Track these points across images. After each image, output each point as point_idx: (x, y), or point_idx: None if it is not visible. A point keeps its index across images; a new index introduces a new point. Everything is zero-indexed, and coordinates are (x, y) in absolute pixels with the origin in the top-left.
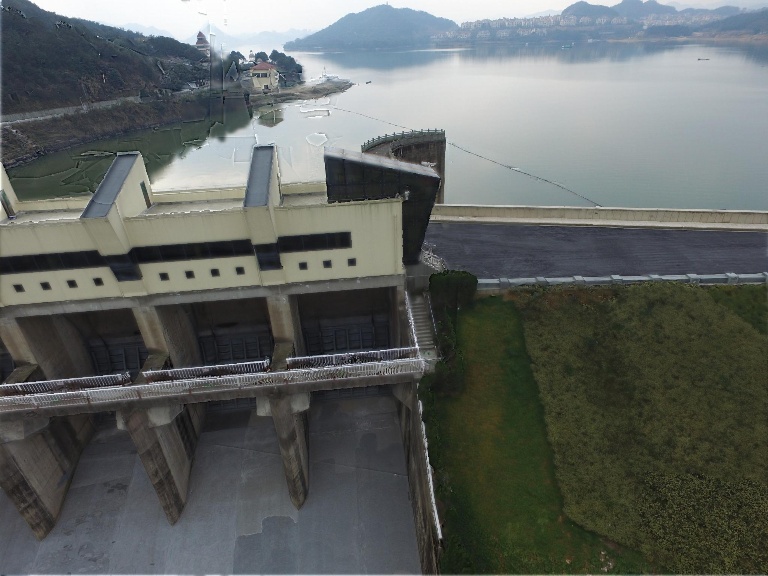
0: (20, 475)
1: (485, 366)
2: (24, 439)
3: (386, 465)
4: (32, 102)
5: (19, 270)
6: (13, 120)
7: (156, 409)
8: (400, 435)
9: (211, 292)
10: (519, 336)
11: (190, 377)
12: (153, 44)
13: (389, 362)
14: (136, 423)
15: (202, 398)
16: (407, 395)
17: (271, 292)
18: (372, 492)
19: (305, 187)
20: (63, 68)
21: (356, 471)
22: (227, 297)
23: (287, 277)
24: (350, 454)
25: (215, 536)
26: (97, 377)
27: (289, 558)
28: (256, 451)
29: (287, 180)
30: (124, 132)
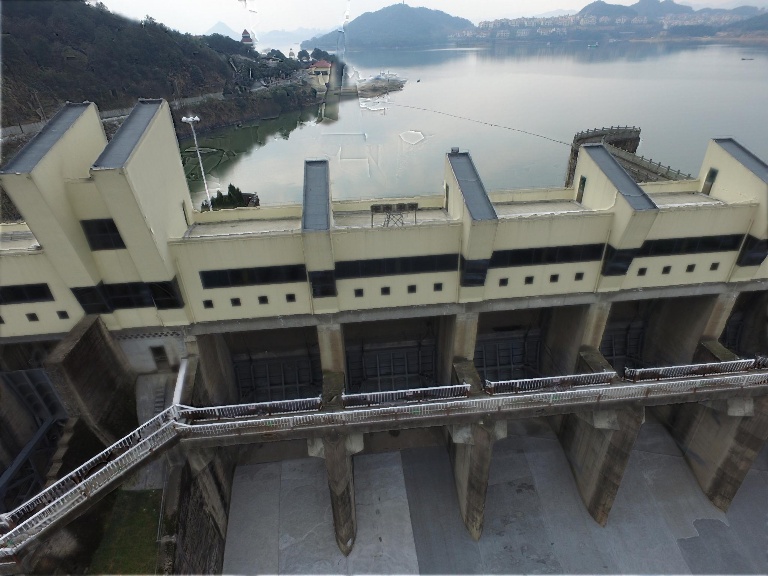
0: None
1: None
2: None
3: None
4: (128, 98)
5: (512, 263)
6: (113, 116)
7: None
8: None
9: (672, 288)
10: None
11: (676, 375)
12: (209, 41)
13: None
14: None
15: (702, 397)
16: None
17: (726, 289)
18: None
19: None
20: (152, 64)
21: (760, 473)
22: (683, 293)
23: (756, 273)
24: None
25: (654, 539)
26: (593, 374)
27: (743, 563)
28: (646, 452)
29: (372, 178)
30: (211, 129)
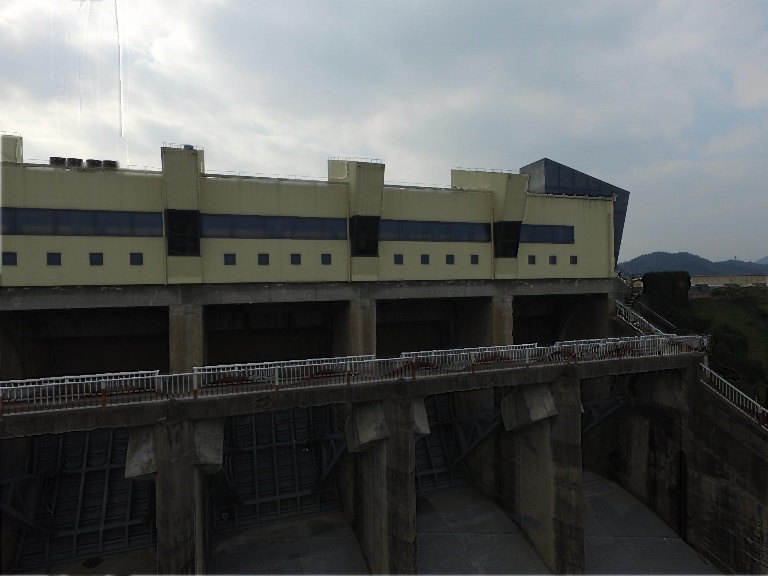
0: (193, 544)
1: (750, 344)
2: (202, 479)
3: (645, 529)
4: None
5: (239, 235)
6: None
7: (417, 408)
8: (632, 497)
9: (439, 285)
10: (759, 318)
11: None
12: None
13: (667, 338)
14: (412, 414)
15: (485, 381)
16: (676, 394)
17: (497, 291)
18: (657, 562)
19: None
20: None
21: (616, 540)
22: (454, 294)
23: (518, 270)
24: (593, 523)
25: None
26: (345, 358)
27: None
28: (473, 533)
29: None
30: None
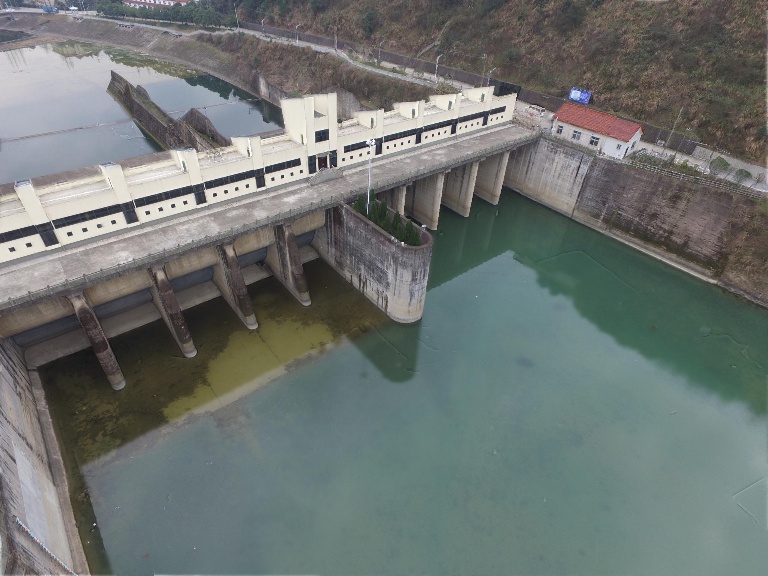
0: None
1: None
2: None
3: None
4: None
5: None
6: None
7: None
8: None
9: None
10: None
11: None
12: None
13: None
14: None
15: None
16: None
17: None
18: None
19: (8, 216)
20: None
21: None
22: None
23: None
24: None
25: None
26: None
27: None
28: None
29: None
30: None
